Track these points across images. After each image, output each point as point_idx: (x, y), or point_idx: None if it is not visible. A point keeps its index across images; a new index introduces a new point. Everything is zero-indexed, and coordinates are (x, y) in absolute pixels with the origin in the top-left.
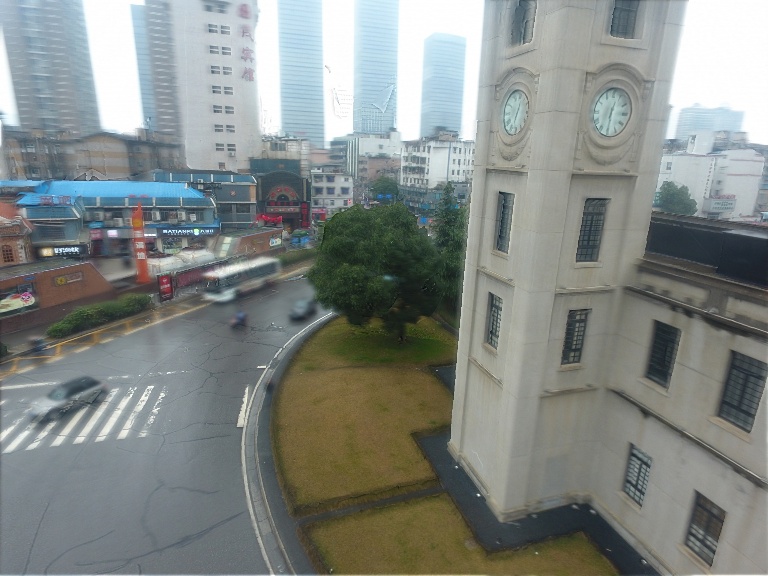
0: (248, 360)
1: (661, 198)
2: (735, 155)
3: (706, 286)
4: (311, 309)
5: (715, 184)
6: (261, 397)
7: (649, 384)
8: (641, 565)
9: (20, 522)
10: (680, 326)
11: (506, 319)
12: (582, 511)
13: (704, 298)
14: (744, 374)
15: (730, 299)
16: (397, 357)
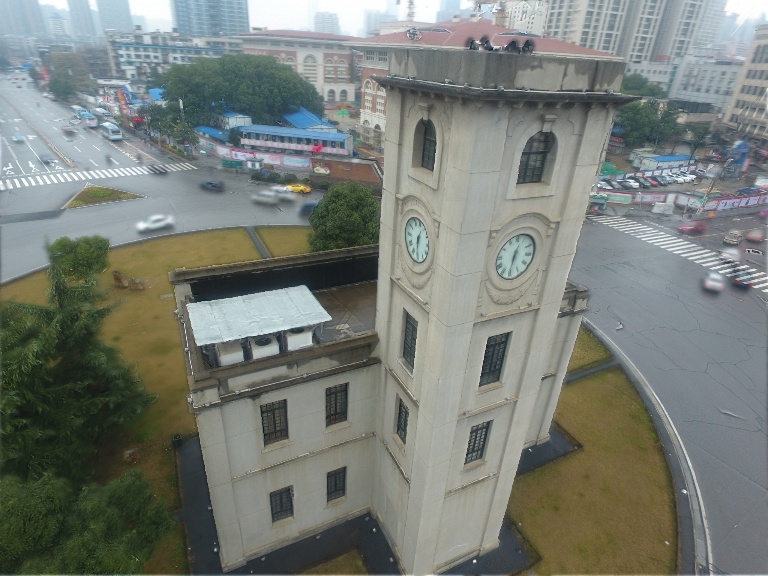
0: None
1: None
2: None
3: None
4: None
5: None
6: None
7: None
8: None
9: None
10: None
11: (500, 429)
12: None
13: None
14: None
15: None
16: None
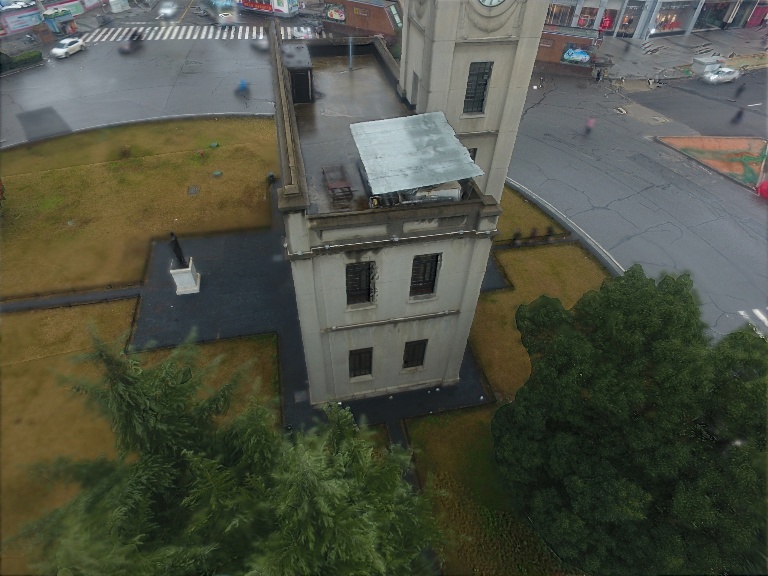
0: None
1: None
2: None
3: None
4: None
5: None
6: None
7: None
8: None
9: (728, 251)
10: None
11: None
12: None
13: None
14: None
15: None
16: None
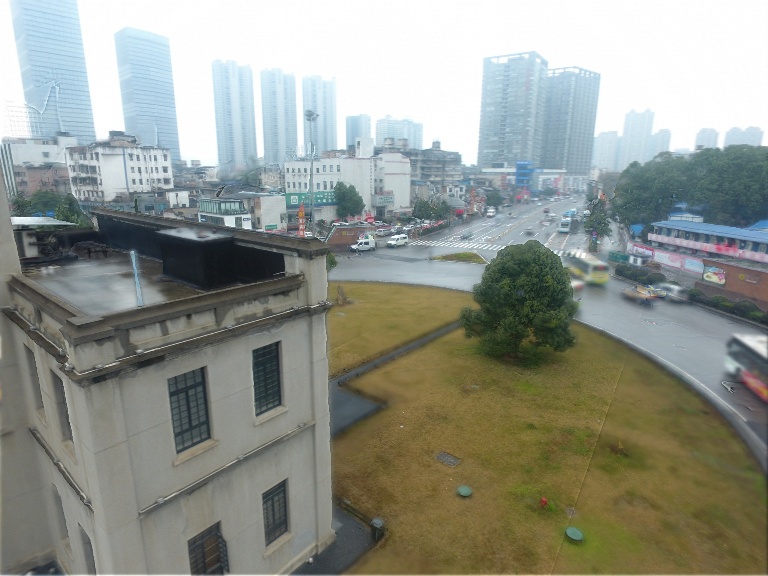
0: None
1: (336, 197)
2: (387, 158)
3: None
4: None
5: (378, 182)
6: None
7: (39, 416)
8: None
9: None
10: (31, 347)
11: None
12: (39, 575)
13: (34, 313)
14: None
15: (40, 311)
16: None
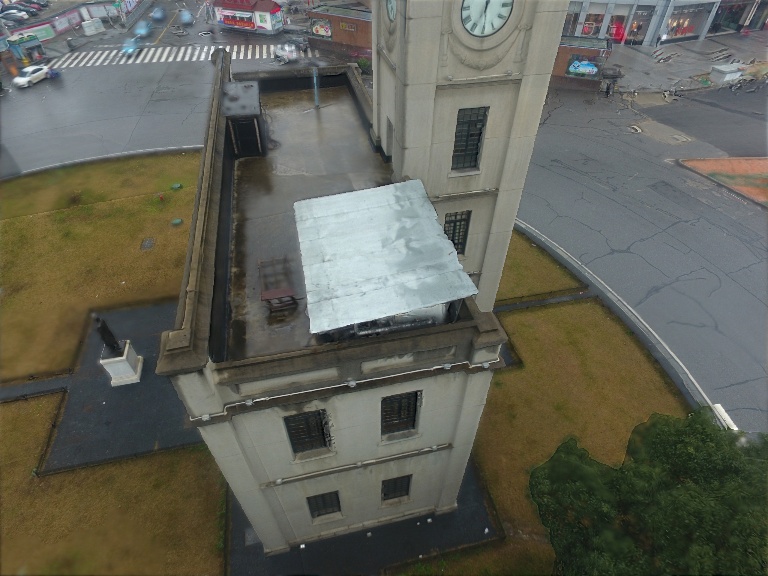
0: None
1: None
2: None
3: None
4: None
5: None
6: None
7: None
8: None
9: None
10: None
11: None
12: None
13: None
14: None
15: None
16: None
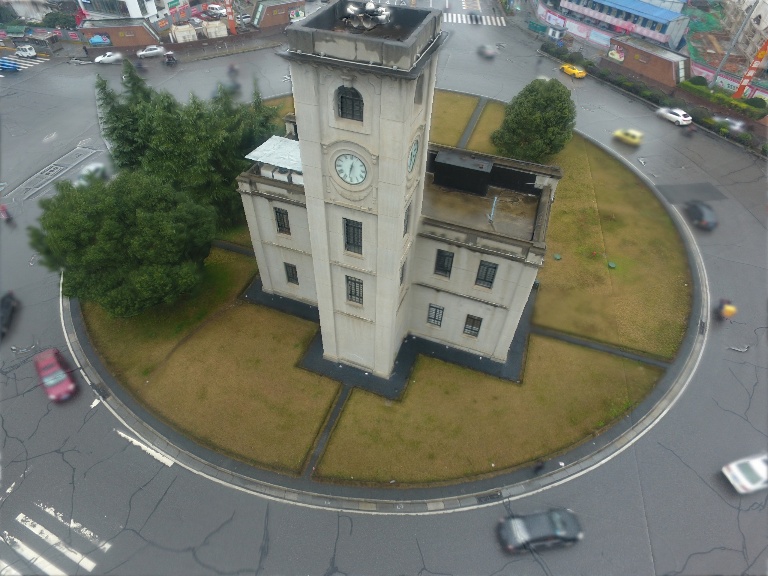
0: (68, 408)
1: None
2: None
3: (466, 233)
4: (29, 299)
5: None
6: (148, 429)
7: (438, 278)
8: (447, 350)
9: None
10: (454, 251)
11: (369, 290)
12: (410, 341)
13: (464, 237)
14: (487, 268)
15: (478, 238)
16: (206, 306)
